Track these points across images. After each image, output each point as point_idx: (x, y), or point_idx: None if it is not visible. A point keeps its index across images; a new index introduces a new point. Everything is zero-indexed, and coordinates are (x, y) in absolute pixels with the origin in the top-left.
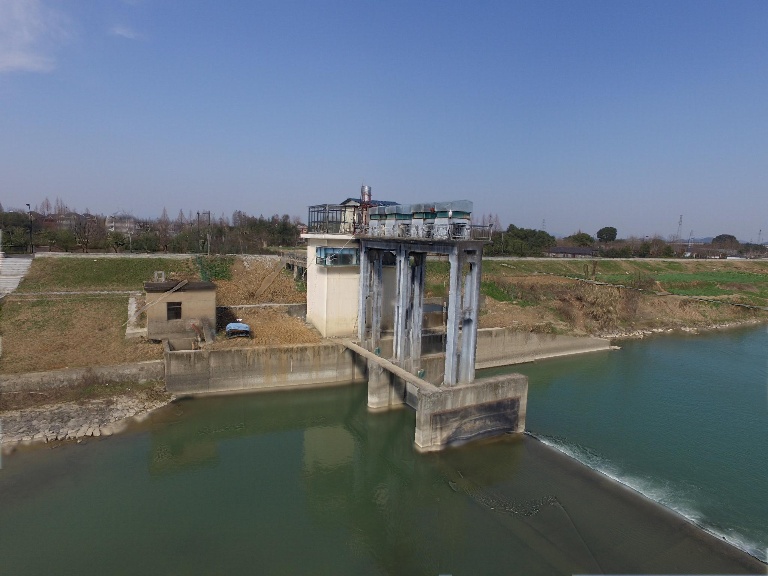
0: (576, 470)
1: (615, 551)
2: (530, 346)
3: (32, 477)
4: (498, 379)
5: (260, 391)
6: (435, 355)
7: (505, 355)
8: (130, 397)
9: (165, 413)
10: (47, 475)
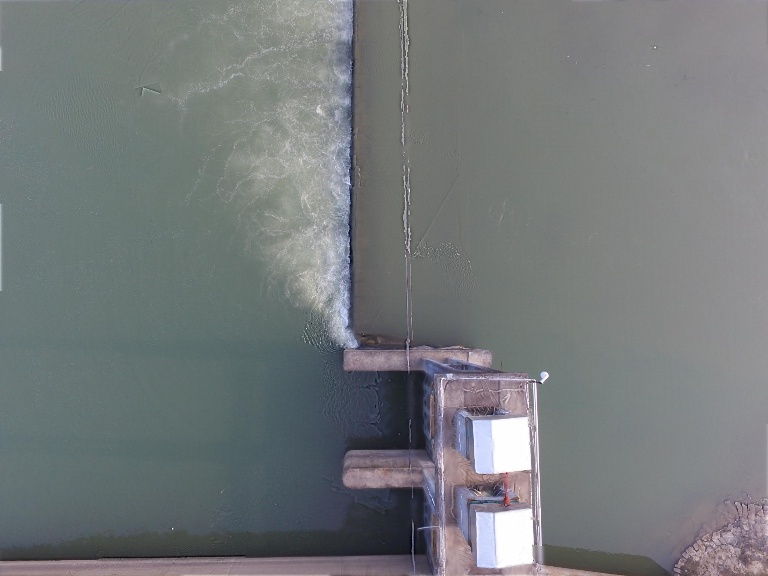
0: (368, 269)
1: (430, 194)
2: (96, 574)
3: (767, 449)
4: (386, 359)
5: (578, 567)
6: (394, 476)
7: (164, 567)
8: (727, 568)
9: (682, 535)
10: (758, 447)
